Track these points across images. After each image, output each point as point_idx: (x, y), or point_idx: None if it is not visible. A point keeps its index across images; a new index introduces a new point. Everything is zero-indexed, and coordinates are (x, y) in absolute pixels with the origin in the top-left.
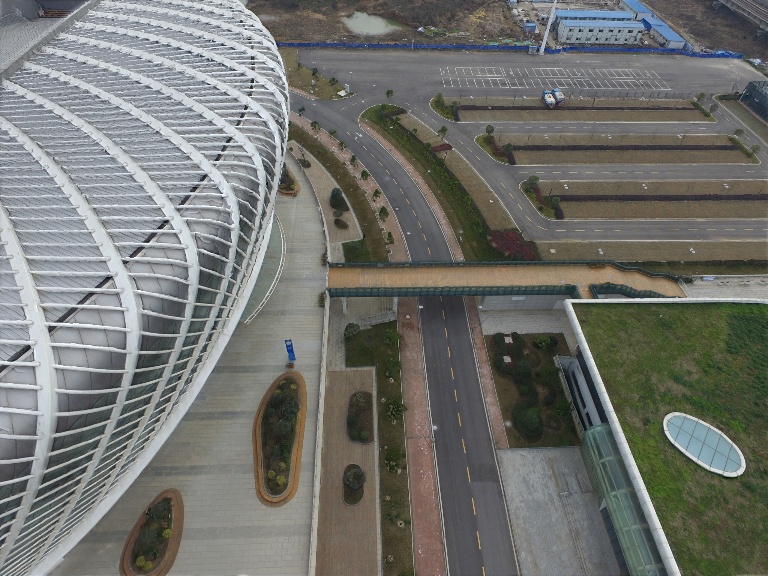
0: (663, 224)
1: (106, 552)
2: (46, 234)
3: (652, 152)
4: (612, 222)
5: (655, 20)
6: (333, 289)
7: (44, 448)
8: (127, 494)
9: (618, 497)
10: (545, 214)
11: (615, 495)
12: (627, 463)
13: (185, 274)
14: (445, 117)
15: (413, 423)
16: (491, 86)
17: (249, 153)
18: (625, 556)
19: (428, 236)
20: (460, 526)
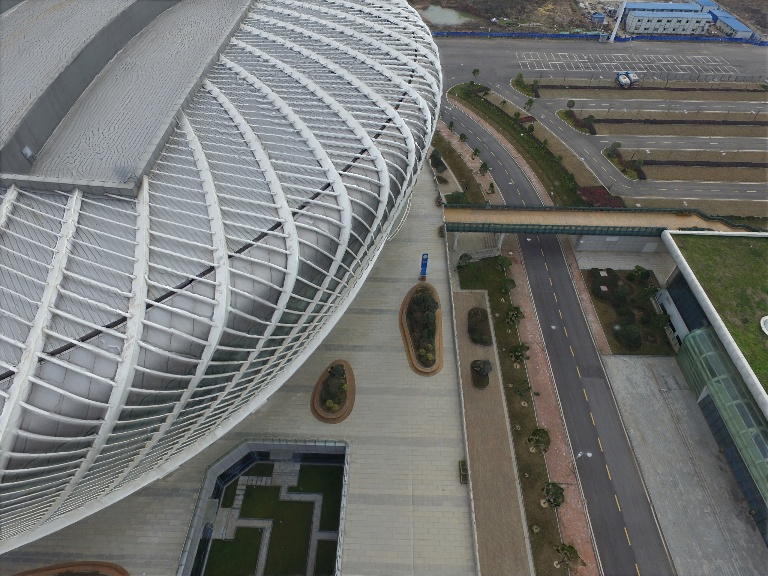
0: (740, 186)
1: (298, 398)
2: (314, 120)
3: (726, 127)
4: (692, 183)
5: (721, 12)
6: (450, 223)
7: (342, 252)
8: (306, 361)
9: (720, 381)
10: (628, 175)
11: (717, 381)
12: (731, 349)
13: (406, 157)
14: (526, 94)
15: (526, 332)
16: (566, 69)
17: (429, 81)
18: (727, 426)
19: (521, 191)
20: (575, 408)
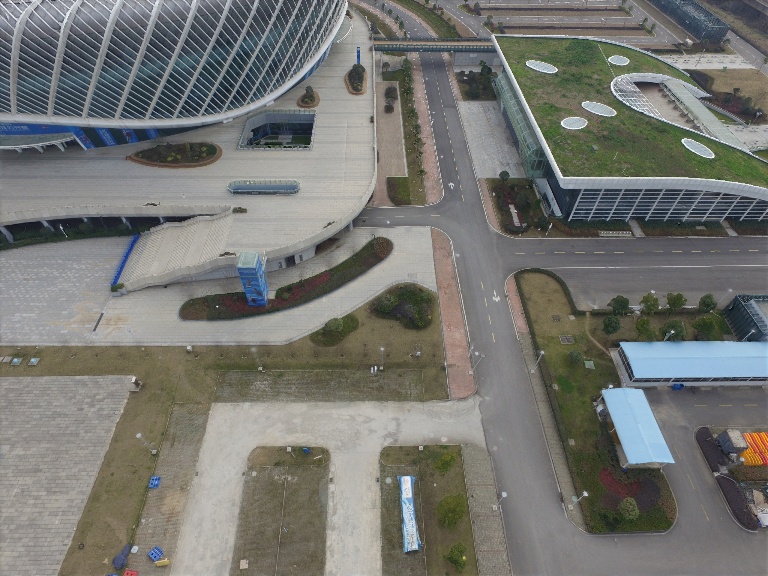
0: None
1: (290, 102)
2: None
3: (567, 12)
4: None
5: None
6: None
7: None
8: (293, 92)
9: None
10: (495, 33)
11: None
12: None
13: None
14: None
15: (417, 94)
16: None
17: None
18: (505, 107)
19: None
20: (438, 117)
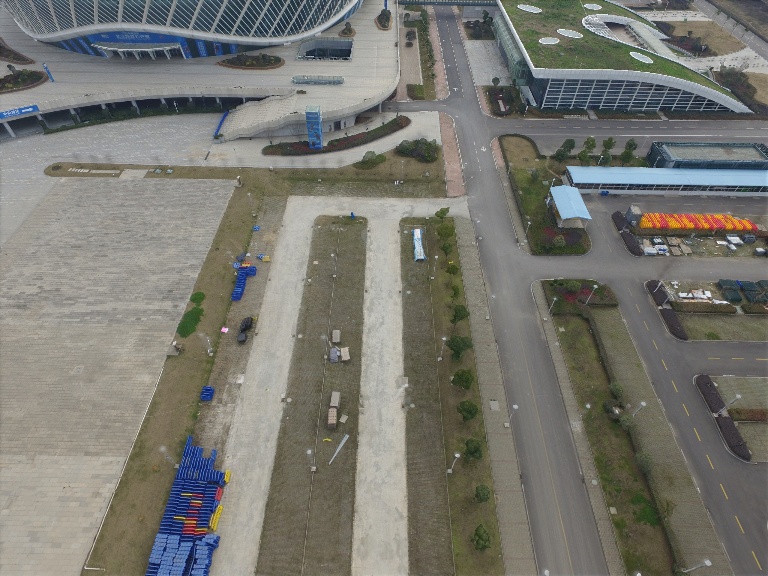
0: None
1: None
2: None
3: None
4: None
5: None
6: None
7: None
8: None
9: None
10: None
11: None
12: None
13: None
14: None
15: (432, 35)
16: None
17: None
18: None
19: None
20: None
